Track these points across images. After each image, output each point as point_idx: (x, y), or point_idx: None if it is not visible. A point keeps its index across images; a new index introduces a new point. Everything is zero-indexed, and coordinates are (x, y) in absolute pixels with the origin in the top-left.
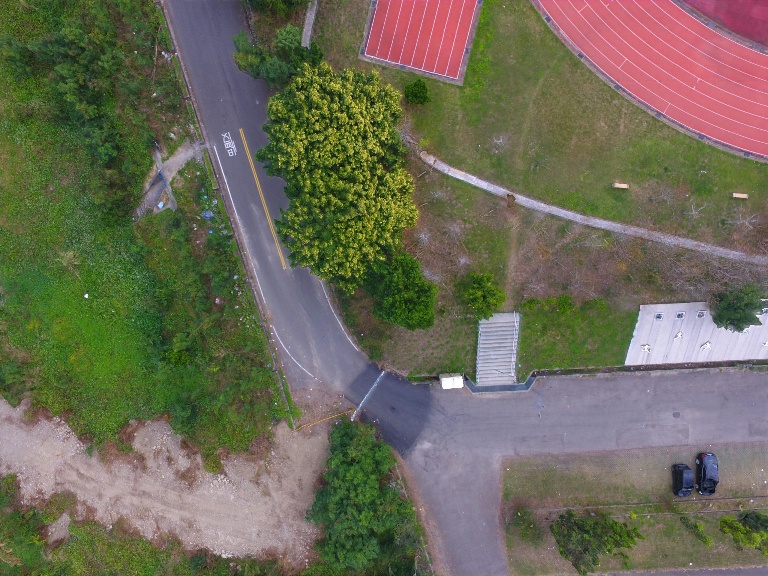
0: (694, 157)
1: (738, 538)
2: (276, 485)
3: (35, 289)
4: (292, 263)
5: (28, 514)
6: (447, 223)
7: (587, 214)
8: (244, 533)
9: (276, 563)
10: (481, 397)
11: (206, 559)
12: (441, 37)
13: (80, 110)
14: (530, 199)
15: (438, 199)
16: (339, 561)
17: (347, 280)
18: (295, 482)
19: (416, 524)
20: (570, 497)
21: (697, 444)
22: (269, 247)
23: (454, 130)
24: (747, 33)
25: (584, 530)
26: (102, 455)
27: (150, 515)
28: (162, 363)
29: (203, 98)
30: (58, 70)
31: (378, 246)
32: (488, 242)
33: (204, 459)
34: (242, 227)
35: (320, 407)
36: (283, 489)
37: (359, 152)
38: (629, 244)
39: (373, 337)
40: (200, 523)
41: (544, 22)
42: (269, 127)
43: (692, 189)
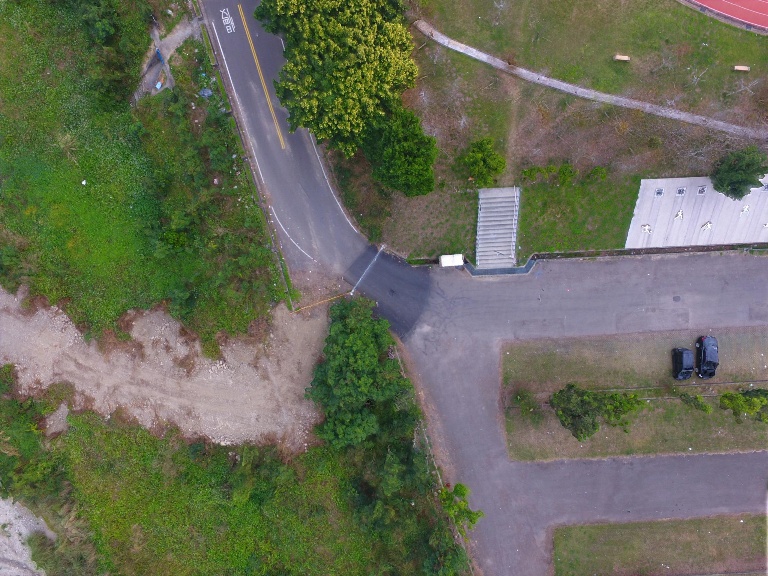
0: (696, 30)
1: (738, 404)
2: (275, 368)
3: (32, 174)
4: (291, 128)
5: (26, 403)
6: (447, 96)
7: (588, 87)
8: (243, 418)
9: (275, 447)
10: (481, 280)
11: (205, 446)
12: None
13: None
14: (530, 72)
15: (438, 72)
16: (338, 438)
17: (346, 142)
18: (294, 365)
19: None
20: (570, 381)
21: (697, 328)
22: (268, 126)
23: (454, 2)
24: None
25: None
26: (100, 344)
27: (148, 404)
28: (160, 243)
29: None
30: None
31: (377, 99)
32: (488, 115)
33: (203, 344)
34: (241, 105)
35: (319, 290)
36: (282, 372)
37: None
38: (630, 118)
39: (372, 215)
40: (199, 410)
41: None
42: None
43: (693, 62)
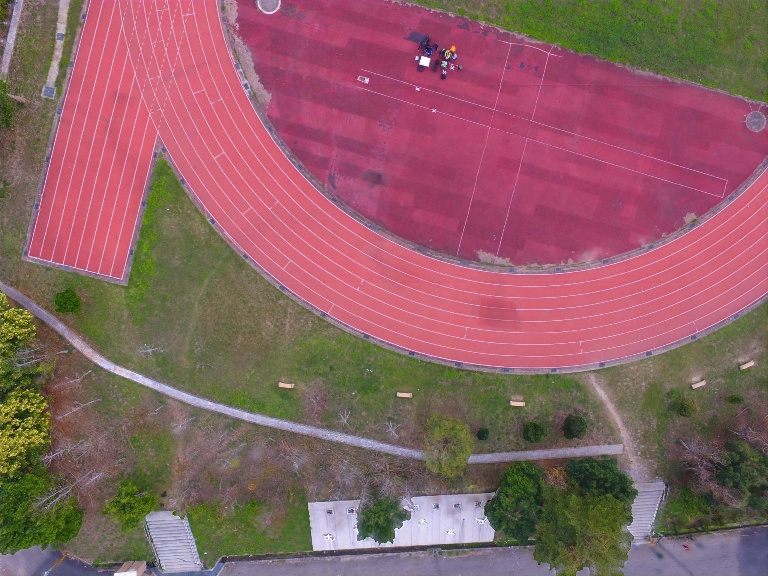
0: (359, 356)
1: None
2: None
3: None
4: None
5: None
6: (114, 421)
7: (254, 412)
8: None
9: None
10: None
11: None
12: (105, 239)
13: None
14: (196, 397)
15: (105, 397)
16: None
17: None
18: None
19: None
20: None
21: None
22: None
23: (120, 329)
24: (409, 236)
25: None
26: None
27: None
28: None
29: None
30: None
31: None
32: (154, 440)
33: None
34: None
35: None
36: None
37: None
38: (296, 442)
39: None
40: None
41: (208, 224)
42: None
43: (358, 387)
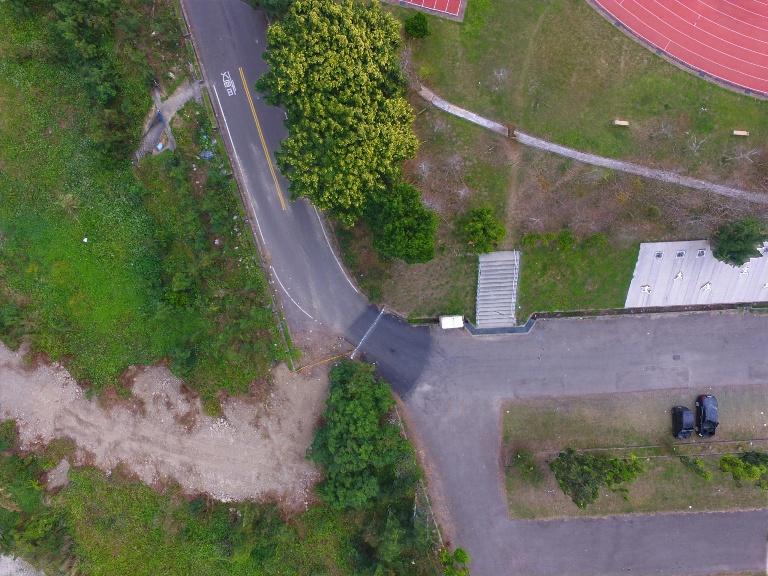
0: (695, 94)
1: (738, 472)
2: (276, 427)
3: (34, 232)
4: (292, 197)
5: (27, 459)
6: (447, 161)
7: (587, 152)
8: (244, 476)
9: (276, 505)
10: (481, 339)
11: (205, 503)
12: None
13: (79, 48)
14: (530, 136)
15: (438, 137)
16: (339, 500)
17: (347, 212)
18: (295, 424)
19: (416, 466)
20: (570, 440)
21: (697, 387)
22: (269, 187)
23: (454, 67)
24: None
25: (584, 464)
26: (101, 400)
27: (149, 460)
28: (161, 304)
29: (202, 37)
30: (57, 7)
31: (378, 174)
32: (488, 180)
33: (203, 402)
34: (241, 167)
35: (320, 349)
36: (283, 431)
37: (359, 75)
38: (629, 182)
39: (373, 277)
40: (199, 467)
41: None
42: (269, 54)
43: (693, 127)
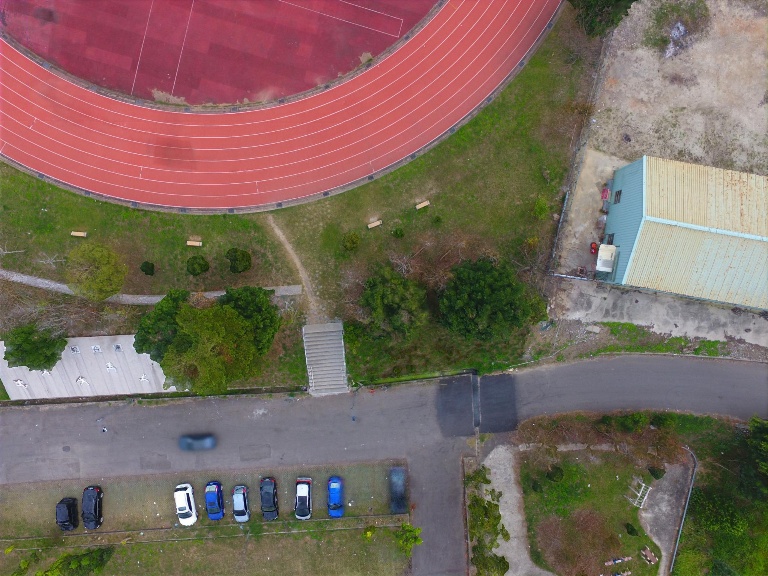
0: (34, 195)
1: None
2: None
3: None
4: None
5: None
6: None
7: None
8: None
9: None
10: None
11: None
12: None
13: None
14: None
15: None
16: None
17: None
18: None
19: None
20: None
21: (89, 478)
22: None
23: None
24: (82, 74)
25: None
26: None
27: None
28: None
29: None
30: None
31: None
32: None
33: None
34: None
35: None
36: None
37: None
38: None
39: None
40: None
41: None
42: None
43: (33, 227)
